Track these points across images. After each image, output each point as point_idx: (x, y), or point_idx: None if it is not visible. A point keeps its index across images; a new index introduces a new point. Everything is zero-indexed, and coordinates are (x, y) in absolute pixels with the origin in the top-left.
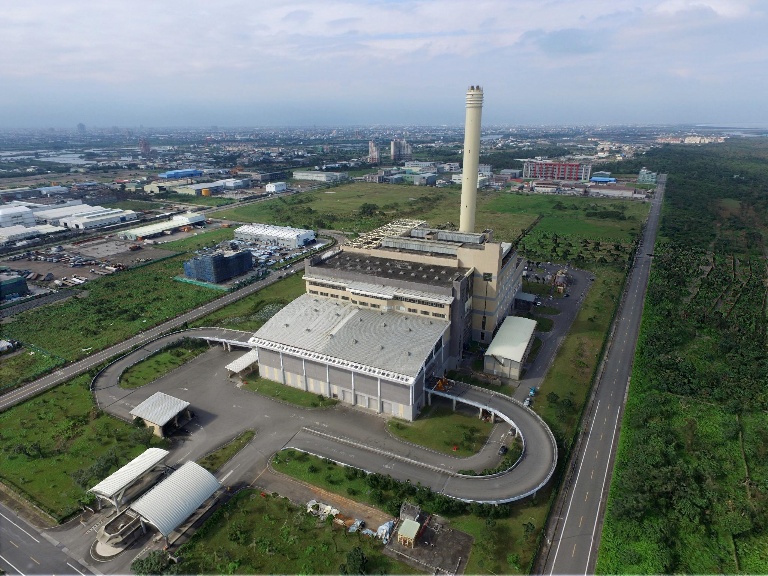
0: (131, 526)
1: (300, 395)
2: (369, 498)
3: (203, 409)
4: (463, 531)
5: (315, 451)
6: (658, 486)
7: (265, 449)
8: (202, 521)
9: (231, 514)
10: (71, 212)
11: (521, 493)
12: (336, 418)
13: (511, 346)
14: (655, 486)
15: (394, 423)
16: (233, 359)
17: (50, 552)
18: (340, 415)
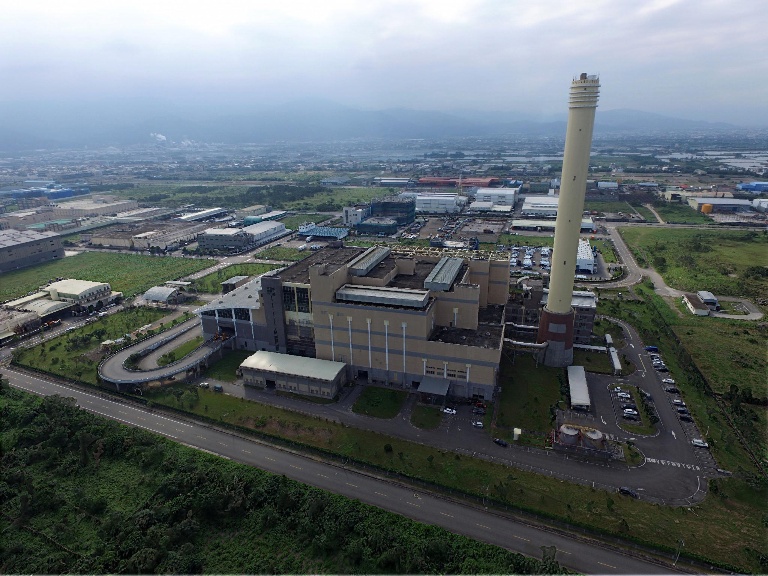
0: None
1: None
2: None
3: None
4: None
5: None
6: None
7: None
8: None
9: None
10: (544, 201)
11: None
12: None
13: (268, 360)
14: None
15: None
16: None
17: None
18: None
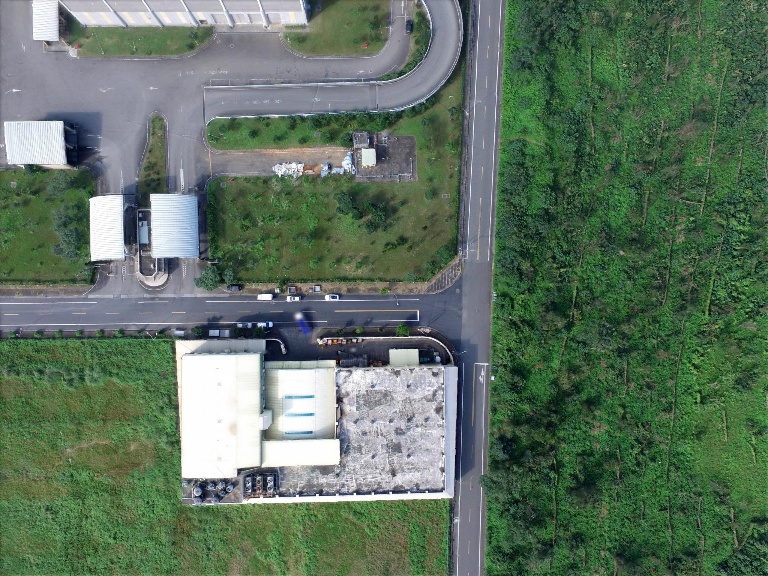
0: (159, 261)
1: (161, 37)
2: (319, 139)
3: (72, 111)
4: (405, 135)
5: (239, 111)
6: (544, 19)
7: (189, 132)
8: (203, 225)
9: (221, 209)
10: None
11: (441, 80)
12: (228, 56)
13: None
14: (542, 21)
15: (291, 35)
16: (13, 5)
17: (115, 303)
18: (229, 49)
